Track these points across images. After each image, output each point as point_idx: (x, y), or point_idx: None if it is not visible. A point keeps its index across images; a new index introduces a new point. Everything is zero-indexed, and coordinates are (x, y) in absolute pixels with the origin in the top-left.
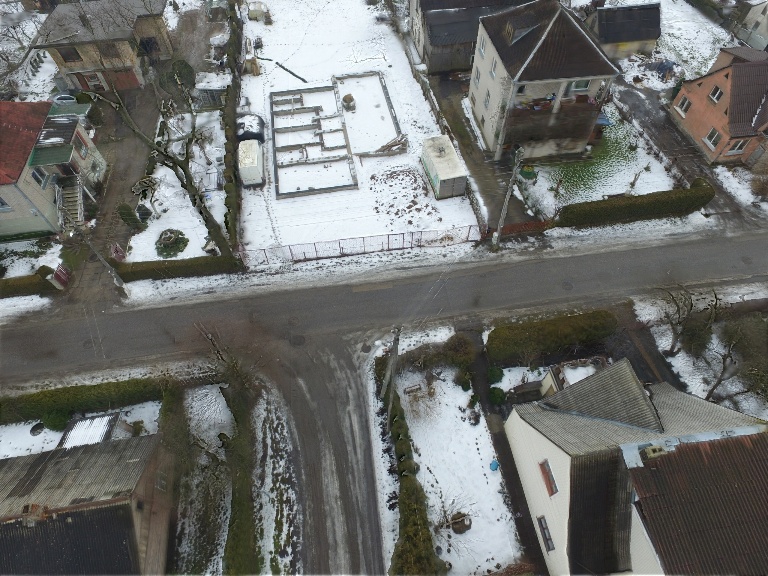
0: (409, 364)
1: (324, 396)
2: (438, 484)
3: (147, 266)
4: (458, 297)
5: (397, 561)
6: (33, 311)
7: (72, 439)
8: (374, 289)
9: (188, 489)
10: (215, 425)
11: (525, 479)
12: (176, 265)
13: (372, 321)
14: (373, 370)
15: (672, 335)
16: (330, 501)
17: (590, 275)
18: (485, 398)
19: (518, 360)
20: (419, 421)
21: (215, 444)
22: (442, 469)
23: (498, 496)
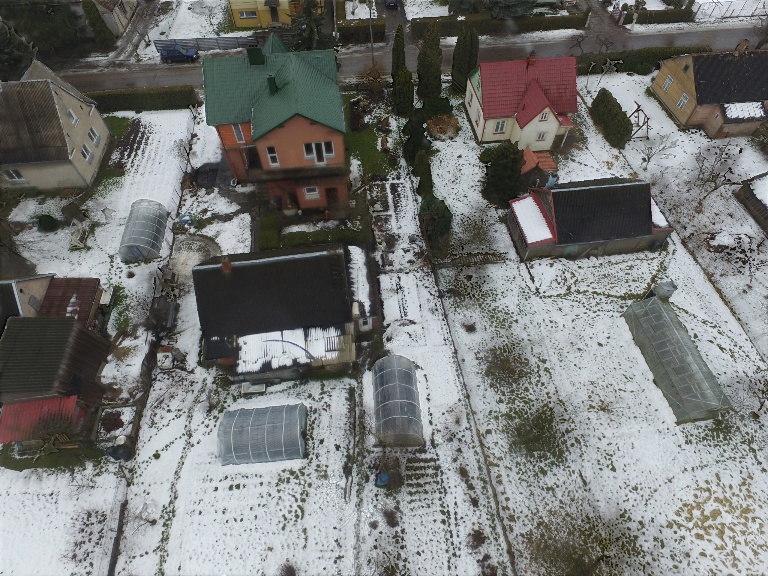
0: None
1: None
2: None
3: (644, 11)
4: None
5: None
6: (577, 35)
7: None
8: None
9: None
10: None
11: None
12: (661, 12)
13: None
14: None
15: None
16: None
17: None
18: None
19: None
20: None
21: None
22: None
23: None
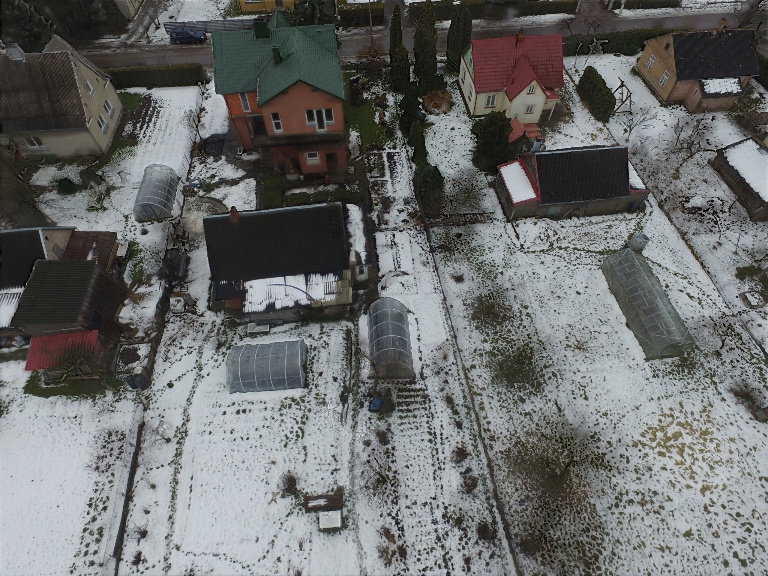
0: None
1: None
2: None
3: None
4: None
5: None
6: (568, 19)
7: None
8: (766, 14)
9: None
10: None
11: None
12: None
13: None
14: None
15: None
16: None
17: None
18: None
19: None
20: None
21: None
22: None
23: None
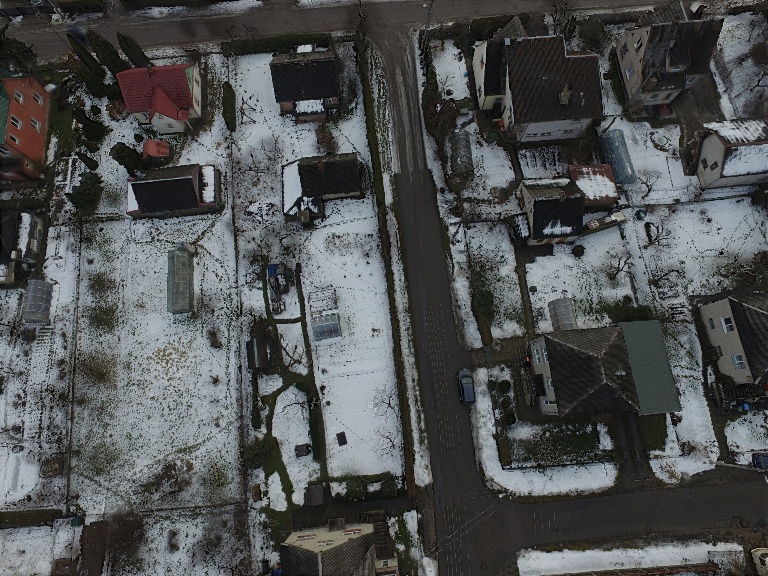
0: (434, 37)
1: (396, 48)
2: (442, 80)
3: None
4: (460, 9)
5: (425, 89)
6: (255, 7)
7: (299, 50)
8: (420, 4)
9: (342, 78)
10: (350, 57)
11: (476, 77)
12: None
13: (418, 18)
14: (418, 39)
15: (554, 27)
16: (399, 83)
17: (528, 2)
18: (466, 52)
19: (482, 32)
20: (436, 59)
21: (351, 64)
22: (444, 75)
23: (465, 85)
